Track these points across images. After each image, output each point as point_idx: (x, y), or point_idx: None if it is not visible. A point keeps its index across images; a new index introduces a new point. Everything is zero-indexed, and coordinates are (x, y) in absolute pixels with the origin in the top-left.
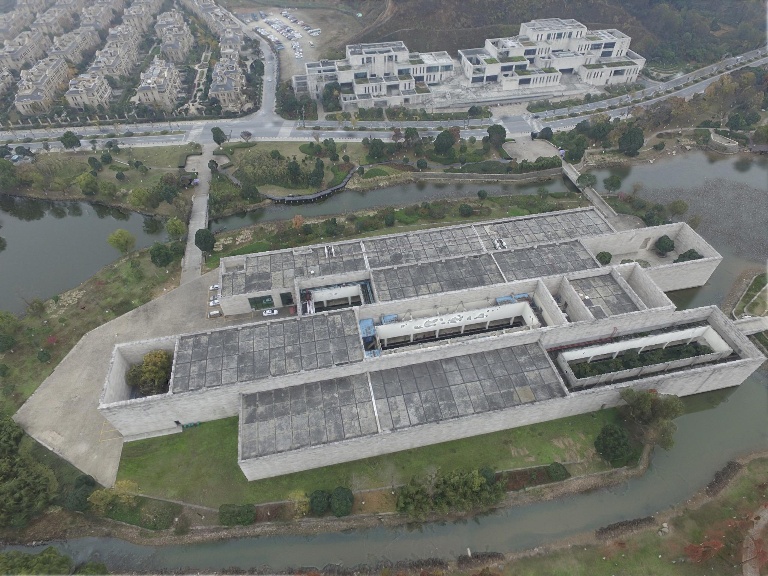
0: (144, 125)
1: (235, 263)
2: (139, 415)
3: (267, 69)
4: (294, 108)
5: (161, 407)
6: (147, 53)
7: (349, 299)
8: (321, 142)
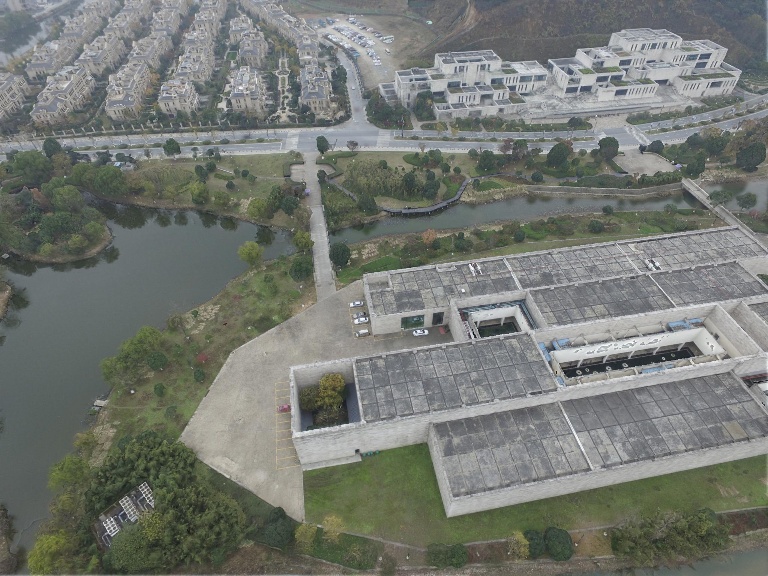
0: (237, 132)
1: (377, 279)
2: (326, 444)
3: (348, 76)
4: (389, 117)
5: (351, 436)
6: (223, 59)
7: (502, 320)
8: (424, 152)
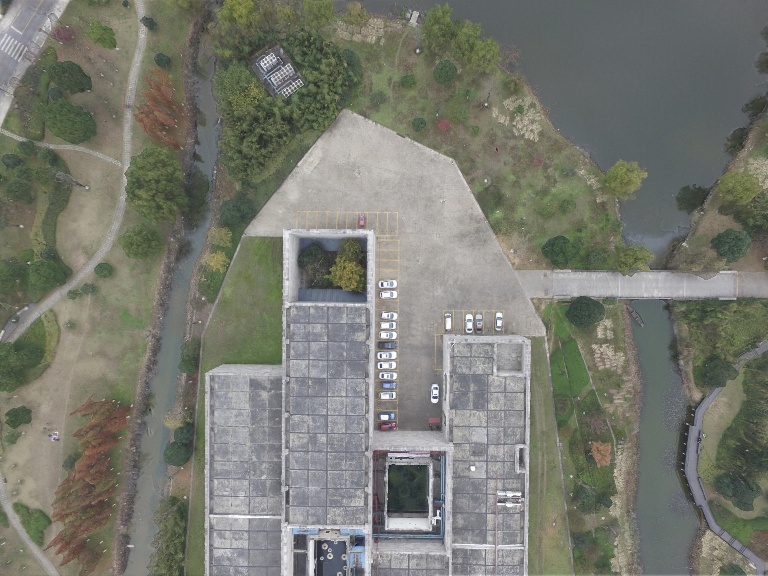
0: None
1: None
2: None
3: None
4: None
5: None
6: None
7: None
8: None
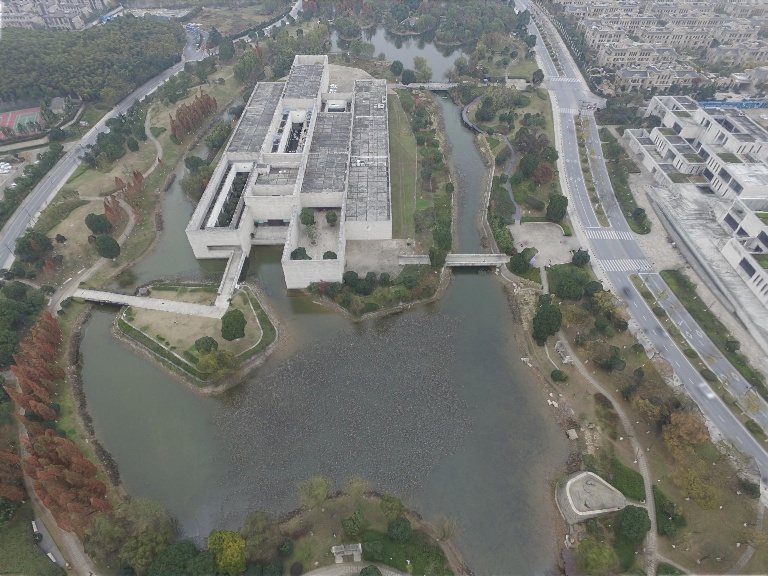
0: None
1: None
2: None
3: None
4: None
5: None
6: None
7: None
8: None
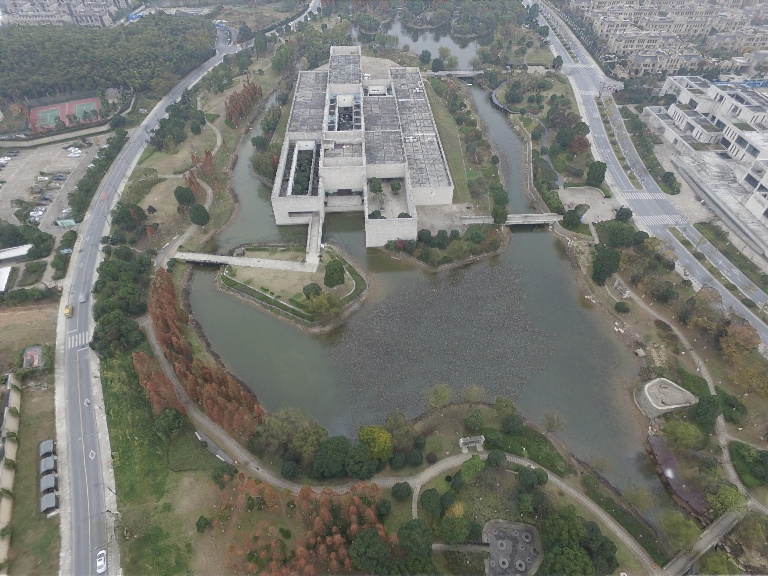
0: None
1: None
2: None
3: None
4: None
5: None
6: None
7: None
8: None
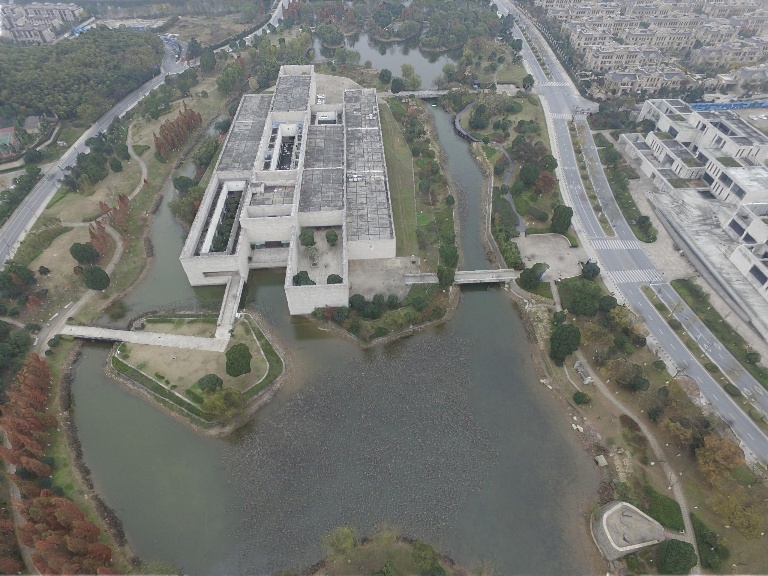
0: (560, 67)
1: None
2: None
3: None
4: None
5: None
6: None
7: None
8: None
